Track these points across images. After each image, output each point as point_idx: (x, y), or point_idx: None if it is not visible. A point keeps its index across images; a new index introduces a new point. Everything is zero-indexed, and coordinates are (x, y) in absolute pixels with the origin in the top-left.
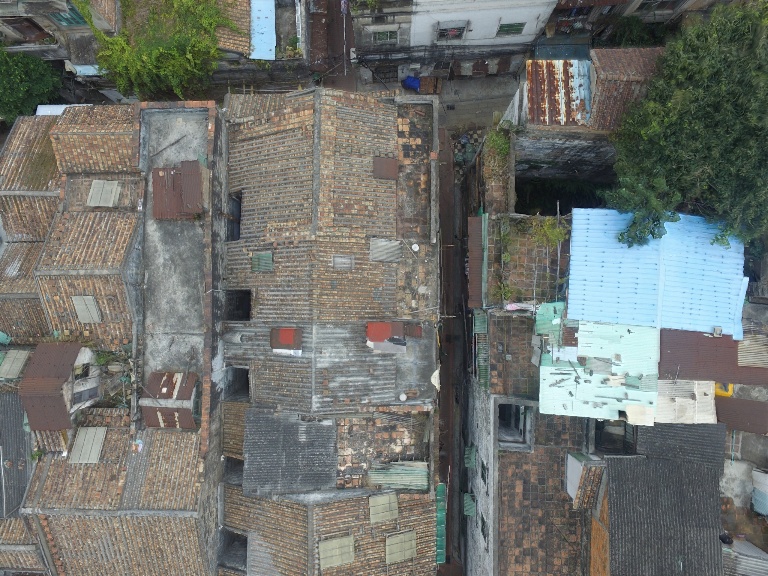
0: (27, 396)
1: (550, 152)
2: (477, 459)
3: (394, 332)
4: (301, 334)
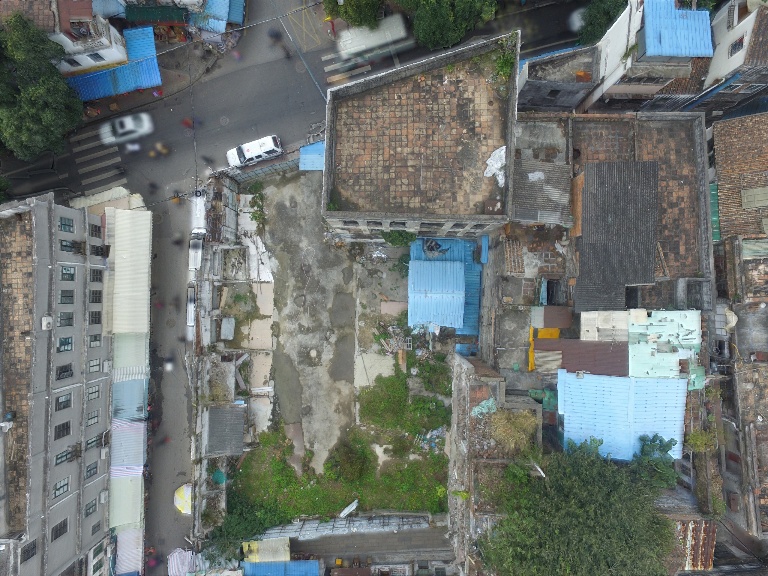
0: None
1: None
2: None
3: None
4: None
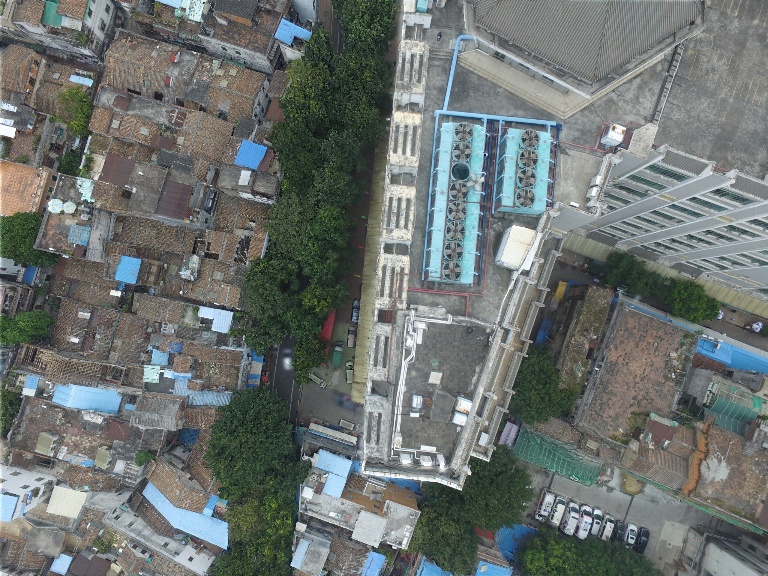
0: (160, 145)
1: (145, 7)
2: (226, 53)
3: (174, 54)
4: (167, 77)
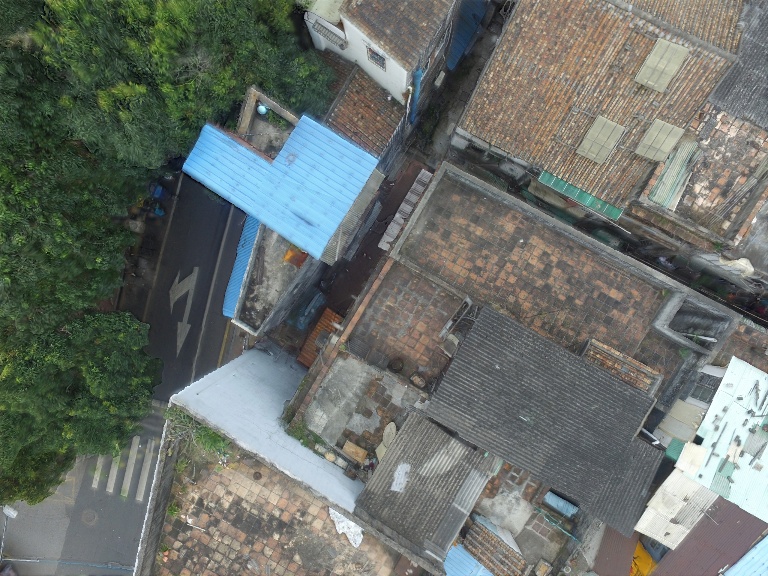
0: None
1: None
2: None
3: None
4: None
